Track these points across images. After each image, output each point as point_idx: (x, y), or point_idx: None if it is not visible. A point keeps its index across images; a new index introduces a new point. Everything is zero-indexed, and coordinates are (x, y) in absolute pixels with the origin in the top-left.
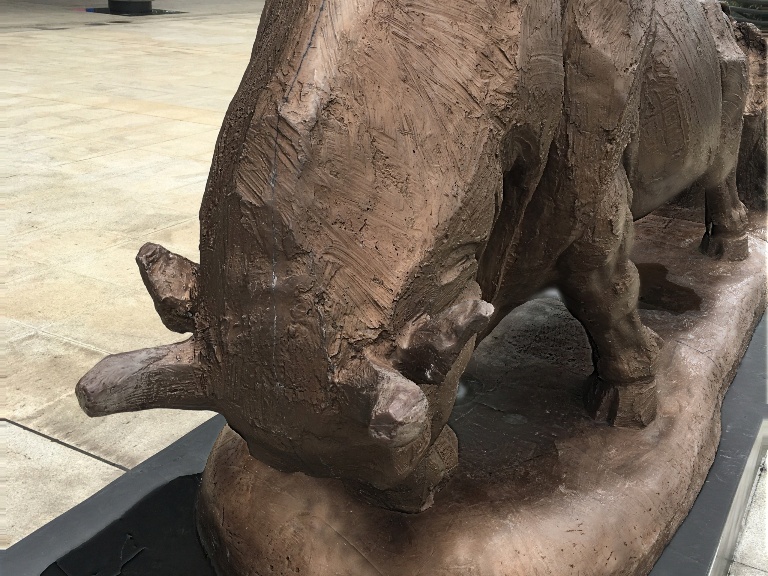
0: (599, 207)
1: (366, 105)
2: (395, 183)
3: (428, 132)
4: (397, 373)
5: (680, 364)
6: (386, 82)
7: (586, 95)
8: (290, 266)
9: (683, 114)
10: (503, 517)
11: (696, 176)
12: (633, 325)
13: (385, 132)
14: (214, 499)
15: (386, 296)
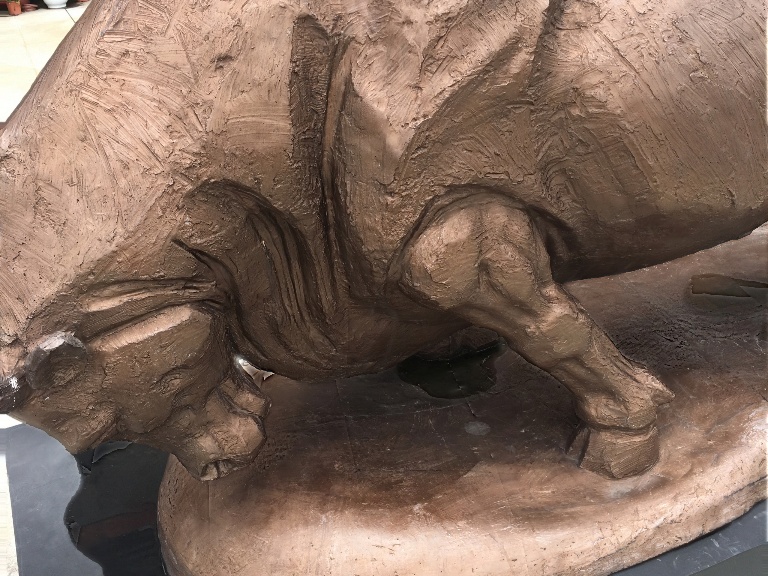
0: (414, 253)
1: (38, 160)
2: (52, 225)
3: (97, 185)
4: None
5: (737, 425)
6: (63, 141)
7: (359, 147)
8: None
9: (639, 154)
10: (323, 511)
11: (725, 219)
12: (591, 370)
13: (52, 183)
14: None
15: (23, 313)
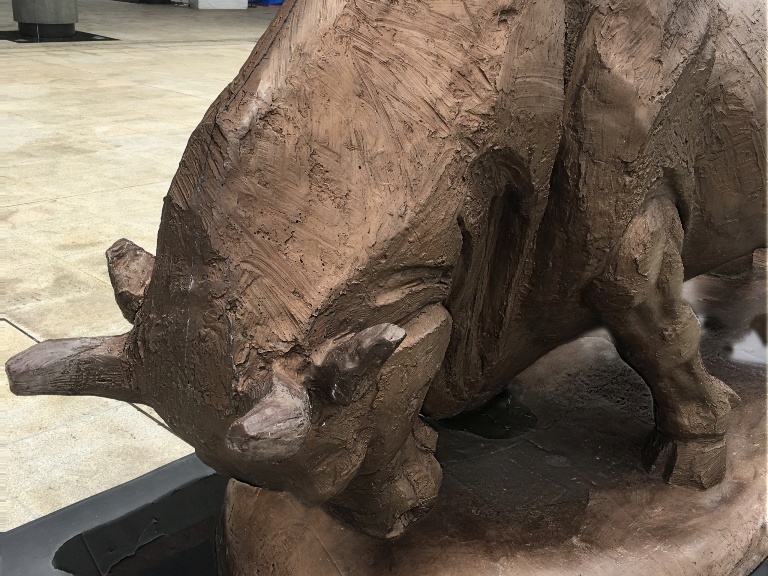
0: (623, 243)
1: (310, 118)
2: (332, 198)
3: (380, 149)
4: (291, 388)
5: None
6: (338, 96)
7: (602, 123)
8: (206, 271)
9: (761, 152)
10: (495, 559)
11: None
12: (694, 376)
13: (328, 146)
14: (228, 497)
15: (304, 310)
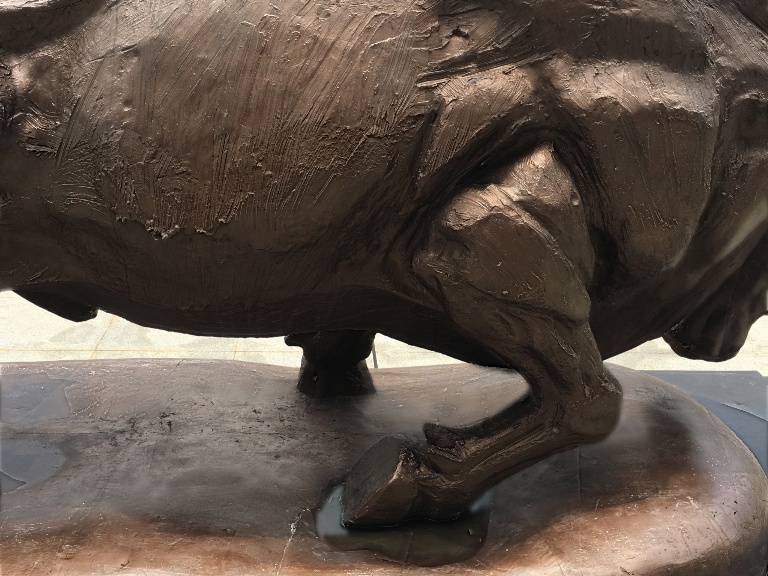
0: None
1: None
2: None
3: None
4: None
5: (224, 365)
6: None
7: None
8: None
9: None
10: None
11: None
12: None
13: None
14: None
15: None
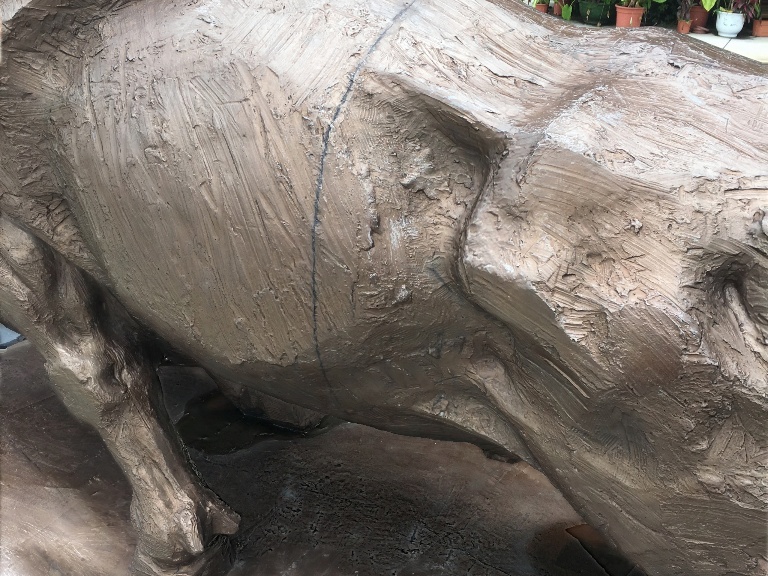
0: None
1: None
2: None
3: None
4: None
5: None
6: None
7: None
8: None
9: (90, 220)
10: None
11: None
12: None
13: None
14: None
15: None
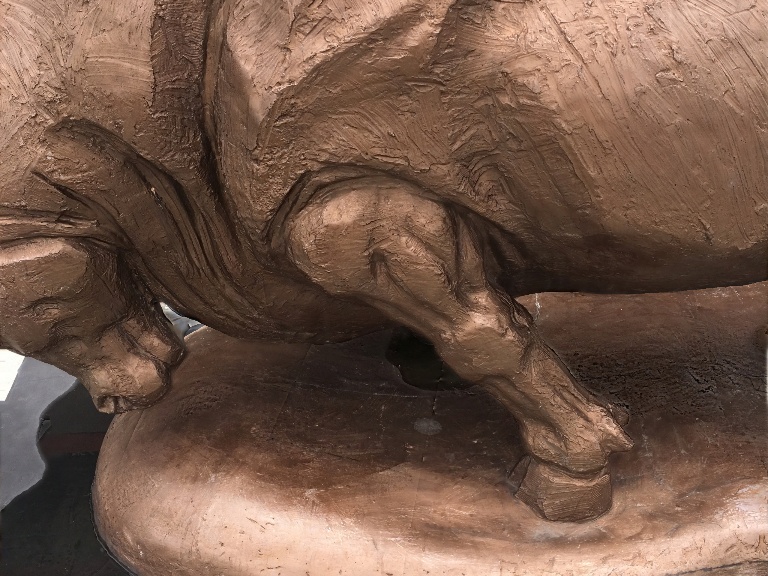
0: (293, 229)
1: None
2: None
3: None
4: None
5: (718, 497)
6: None
7: (230, 105)
8: None
9: (578, 160)
10: (215, 470)
11: (704, 255)
12: (525, 395)
13: None
14: None
15: None
